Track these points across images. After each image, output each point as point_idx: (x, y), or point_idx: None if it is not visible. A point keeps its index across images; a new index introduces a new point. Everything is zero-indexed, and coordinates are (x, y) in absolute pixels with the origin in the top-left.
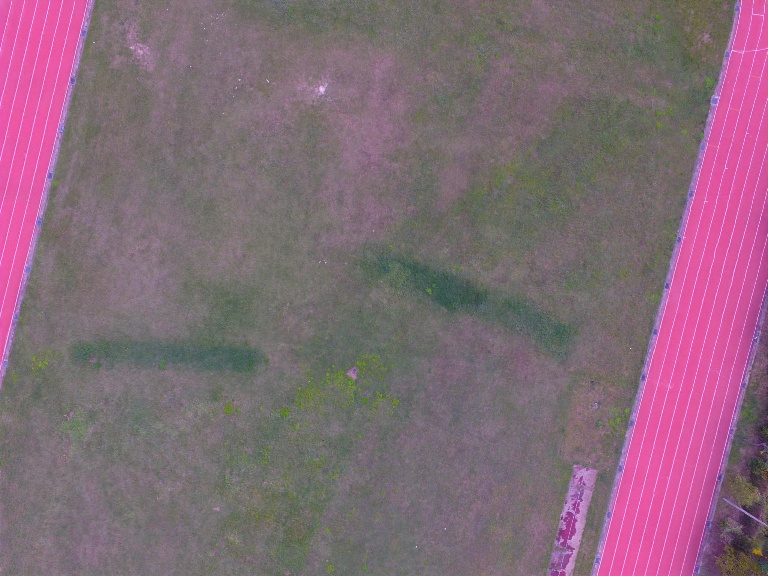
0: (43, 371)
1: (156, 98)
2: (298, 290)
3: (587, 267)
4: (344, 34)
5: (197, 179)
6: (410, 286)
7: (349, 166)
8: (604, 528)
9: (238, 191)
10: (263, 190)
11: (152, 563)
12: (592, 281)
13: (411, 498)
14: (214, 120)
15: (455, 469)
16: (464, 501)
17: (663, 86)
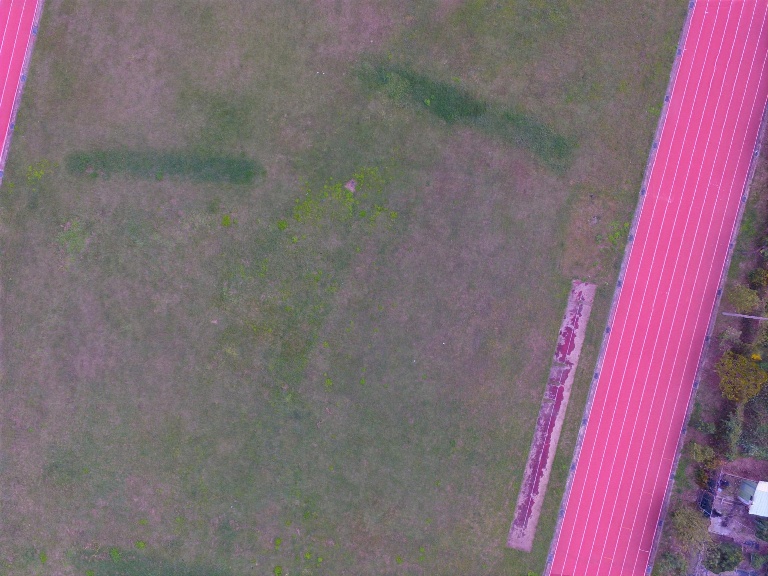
0: (39, 181)
1: None
2: (296, 101)
3: (587, 79)
4: None
5: None
6: (408, 98)
7: None
8: (603, 343)
9: None
10: None
11: (150, 376)
12: (592, 93)
13: (409, 312)
14: None
15: (454, 283)
16: (463, 316)
17: None
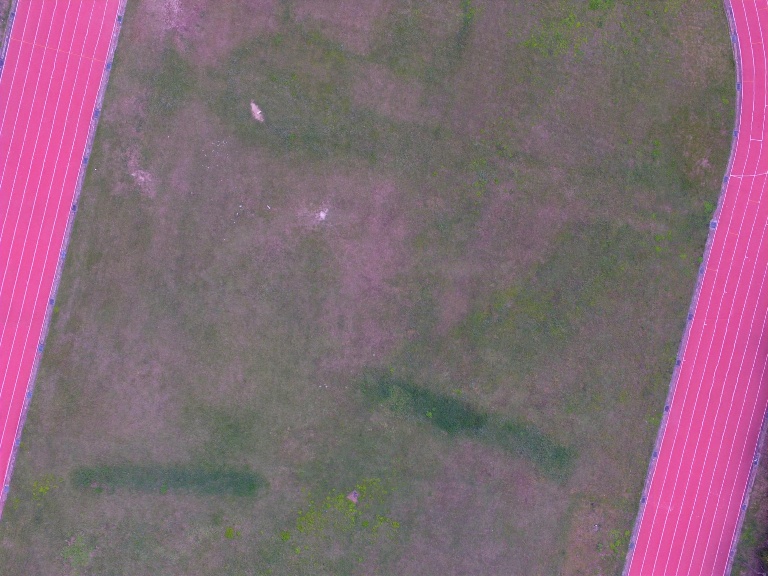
0: (44, 496)
1: (157, 224)
2: (299, 414)
3: (587, 390)
4: (344, 160)
5: (198, 304)
6: (410, 410)
7: (349, 291)
8: None
9: (239, 316)
10: (264, 315)
11: None
12: (592, 404)
13: None
14: (215, 246)
15: None
16: None
17: (662, 211)
